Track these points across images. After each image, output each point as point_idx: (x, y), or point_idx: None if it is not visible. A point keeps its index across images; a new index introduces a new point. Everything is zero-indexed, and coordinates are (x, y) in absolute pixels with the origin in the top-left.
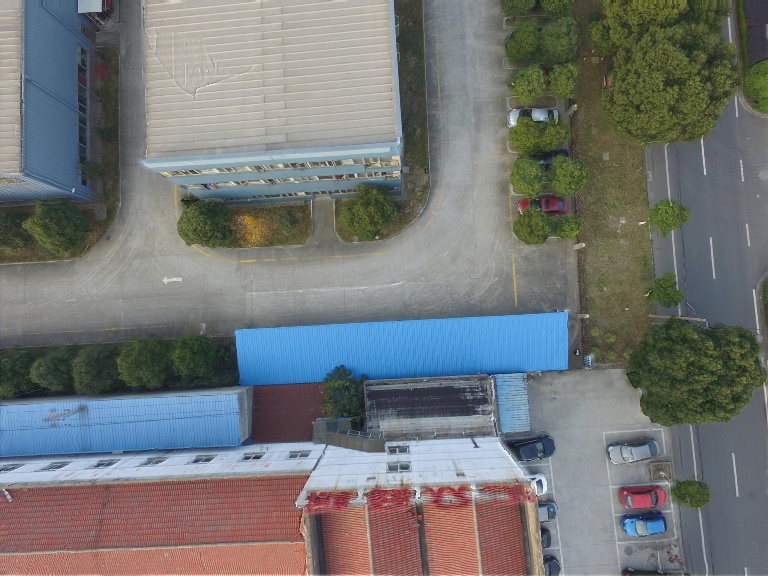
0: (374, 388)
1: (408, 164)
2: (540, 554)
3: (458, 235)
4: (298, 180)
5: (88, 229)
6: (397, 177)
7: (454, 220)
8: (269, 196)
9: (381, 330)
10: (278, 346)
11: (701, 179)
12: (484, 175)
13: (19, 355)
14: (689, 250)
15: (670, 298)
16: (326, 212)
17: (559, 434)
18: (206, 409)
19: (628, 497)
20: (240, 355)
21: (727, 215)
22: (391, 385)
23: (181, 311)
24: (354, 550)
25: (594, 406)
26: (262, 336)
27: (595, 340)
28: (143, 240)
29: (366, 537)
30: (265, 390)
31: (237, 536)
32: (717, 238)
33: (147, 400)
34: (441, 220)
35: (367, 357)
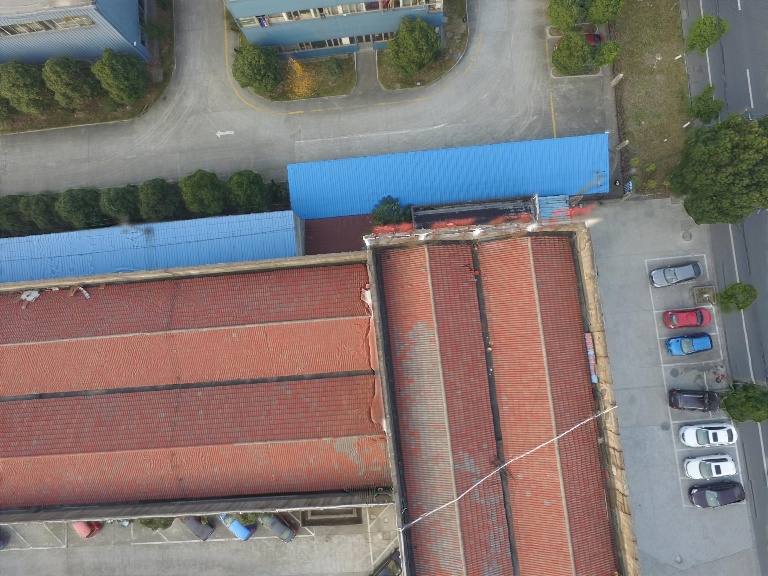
0: (421, 213)
1: (446, 14)
2: (596, 289)
3: (497, 78)
4: (346, 12)
5: (147, 86)
6: (439, 8)
7: (492, 64)
8: (315, 47)
9: (426, 159)
10: (328, 179)
11: (736, 14)
12: (520, 21)
13: (89, 190)
14: (726, 82)
15: (710, 109)
16: (369, 63)
17: (601, 263)
18: (264, 226)
19: (673, 317)
20: (292, 189)
21: (763, 47)
22: (437, 210)
23: (234, 161)
24: (416, 299)
25: (635, 235)
26: (313, 169)
27: (634, 172)
28: (197, 98)
29: (427, 283)
30: (316, 223)
31: (300, 315)
32: (754, 69)
33: (209, 219)
34: (480, 65)
35: (413, 186)
